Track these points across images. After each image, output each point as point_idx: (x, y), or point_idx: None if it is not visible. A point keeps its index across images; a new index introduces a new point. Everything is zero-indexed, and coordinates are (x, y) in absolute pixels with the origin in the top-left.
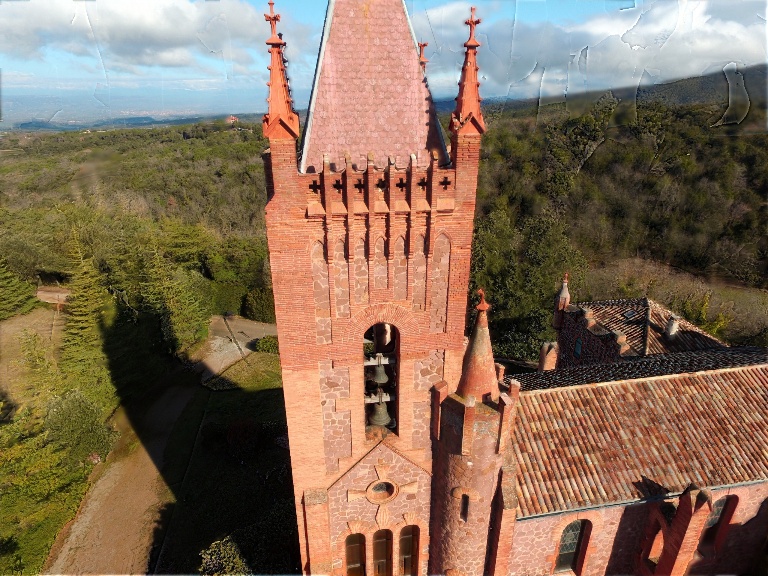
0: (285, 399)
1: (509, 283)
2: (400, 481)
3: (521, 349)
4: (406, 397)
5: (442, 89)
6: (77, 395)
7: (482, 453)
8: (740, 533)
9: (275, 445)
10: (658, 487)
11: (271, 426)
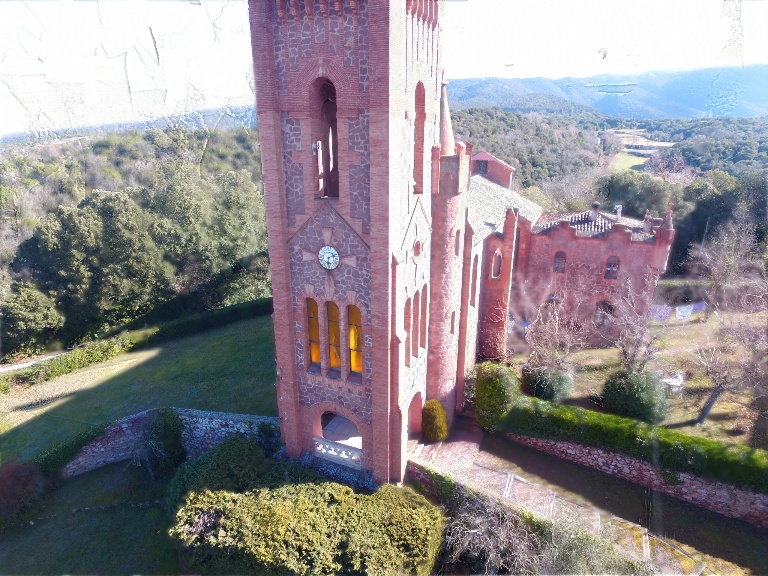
0: (390, 146)
1: (229, 228)
2: (422, 239)
3: (250, 293)
4: (425, 155)
5: (6, 59)
6: None
7: None
8: (498, 263)
9: (65, 479)
10: (491, 224)
11: (55, 452)
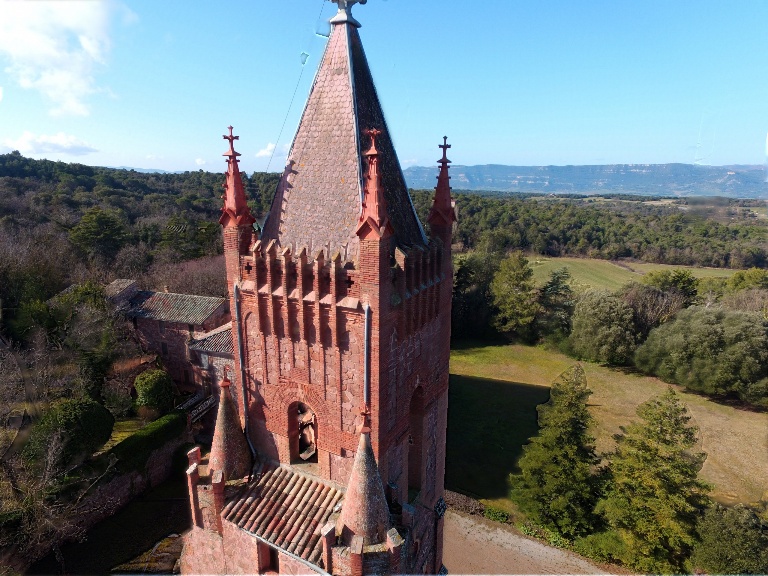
0: None
1: None
2: None
3: None
4: None
5: None
6: (744, 518)
7: None
8: None
9: None
10: None
11: None
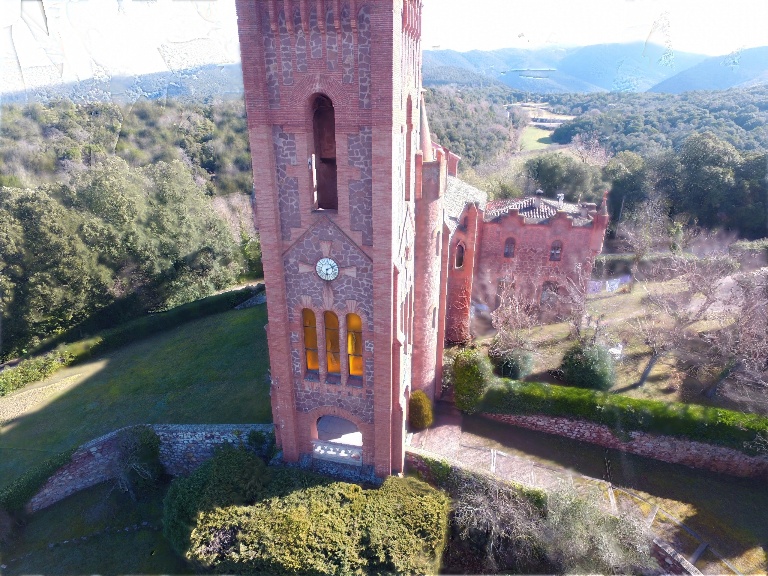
0: None
1: (167, 224)
2: None
3: (194, 291)
4: None
5: None
6: None
7: (443, 193)
8: None
9: (31, 514)
10: None
11: (17, 487)
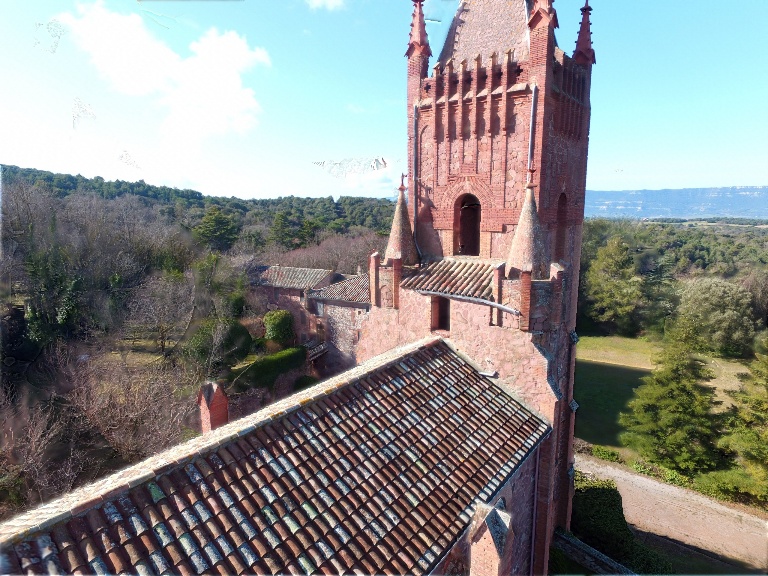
0: None
1: None
2: None
3: None
4: None
5: None
6: None
7: None
8: None
9: None
10: None
11: None
